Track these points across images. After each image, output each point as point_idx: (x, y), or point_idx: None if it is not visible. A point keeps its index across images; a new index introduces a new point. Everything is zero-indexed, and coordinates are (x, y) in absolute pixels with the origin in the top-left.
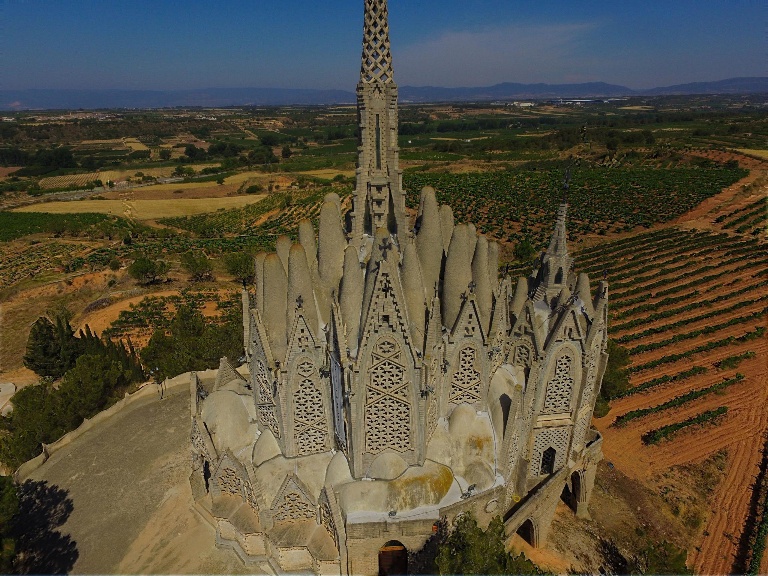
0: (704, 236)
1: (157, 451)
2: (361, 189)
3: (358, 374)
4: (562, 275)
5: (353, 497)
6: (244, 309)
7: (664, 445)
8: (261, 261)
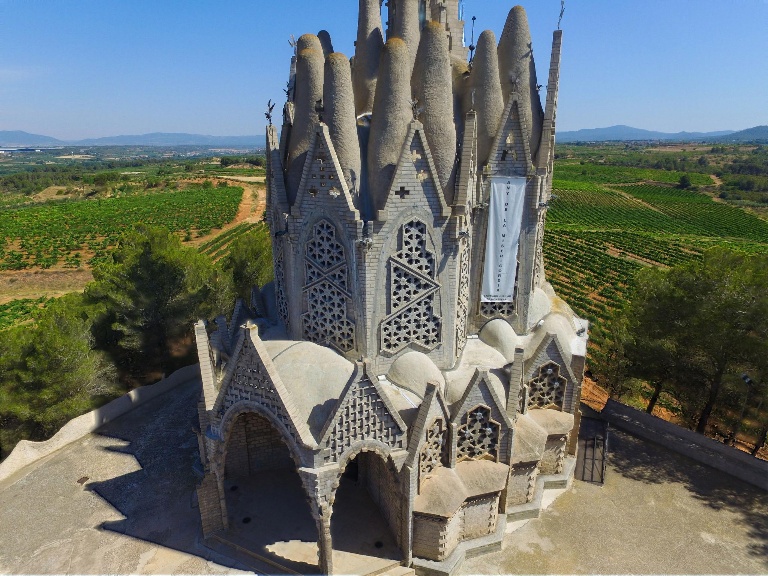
0: None
1: None
2: None
3: None
4: None
5: None
6: (333, 156)
7: None
8: None
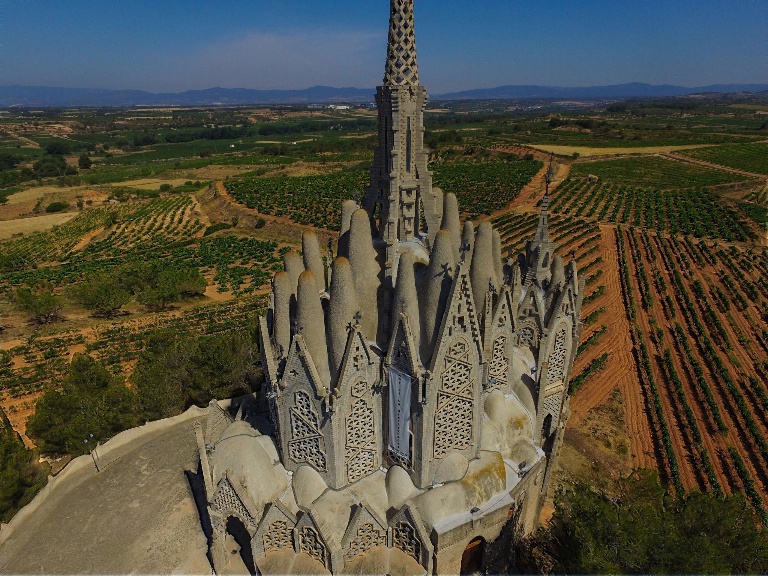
0: (534, 218)
1: (130, 534)
2: (396, 194)
3: (432, 381)
4: (548, 259)
5: (436, 507)
6: (264, 338)
7: (577, 394)
8: (284, 281)
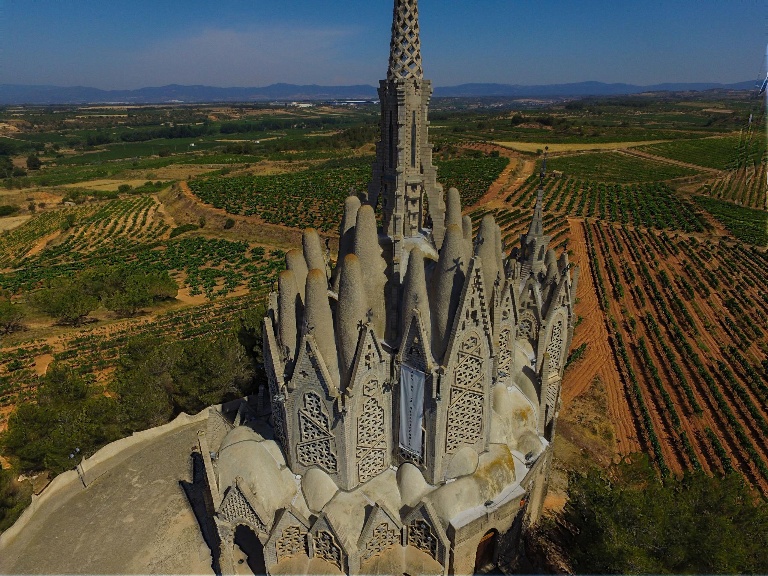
0: (505, 213)
1: (127, 550)
2: (403, 189)
3: (445, 376)
4: (543, 252)
5: (451, 502)
6: (270, 340)
7: None
8: (290, 280)
